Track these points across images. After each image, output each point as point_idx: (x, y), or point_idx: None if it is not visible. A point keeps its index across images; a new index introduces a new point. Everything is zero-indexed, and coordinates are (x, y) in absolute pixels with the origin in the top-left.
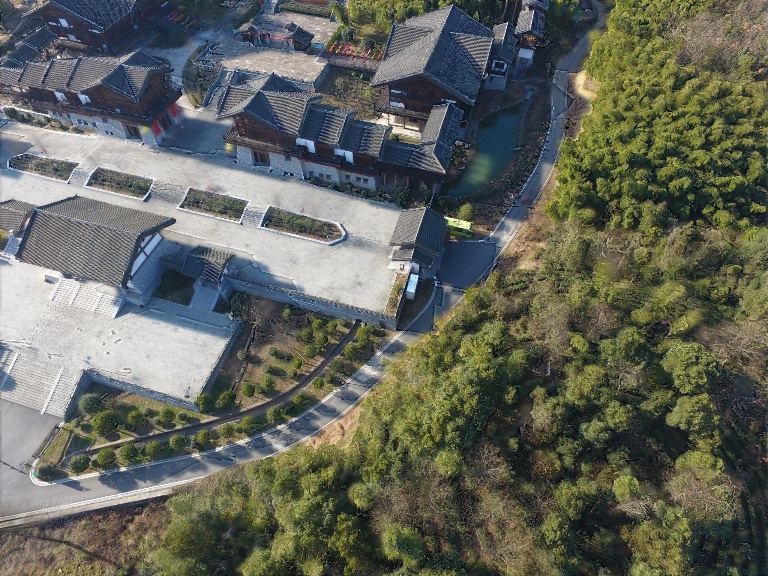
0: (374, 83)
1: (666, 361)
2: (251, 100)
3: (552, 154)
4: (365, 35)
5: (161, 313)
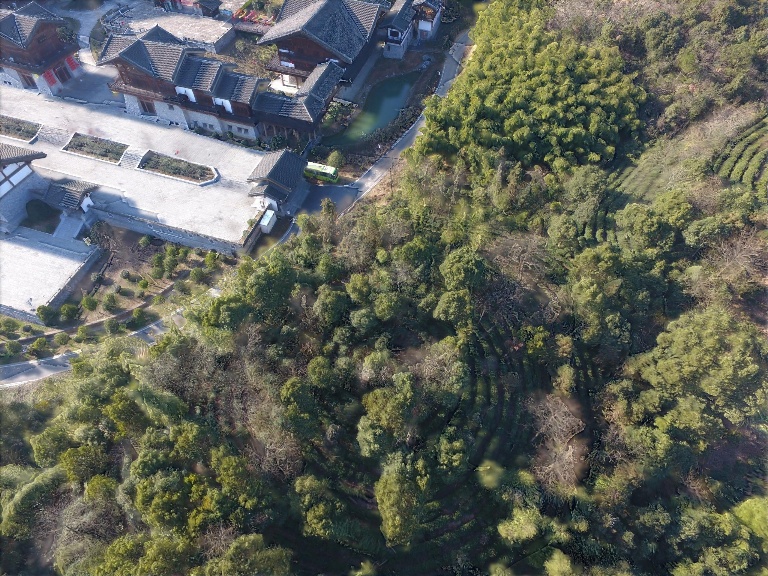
0: (260, 41)
1: (442, 264)
2: (128, 47)
3: None
4: (276, 6)
5: (25, 240)
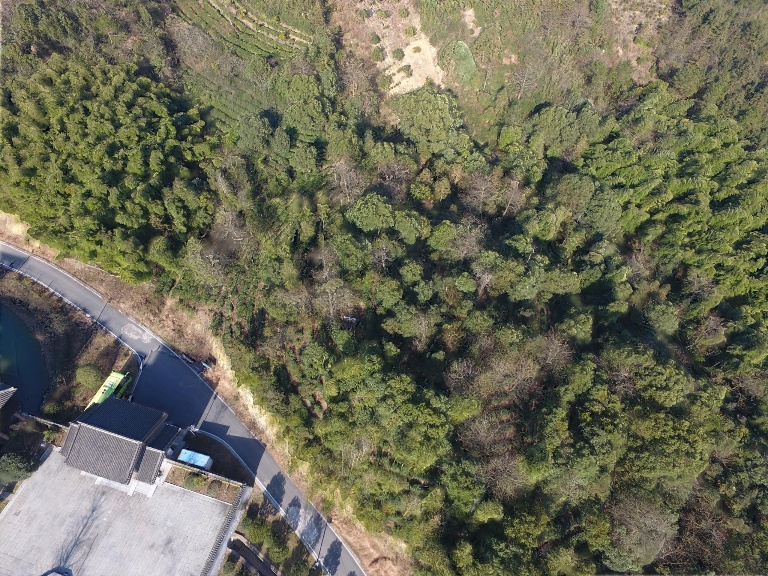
0: None
1: (366, 226)
2: None
3: (23, 260)
4: None
5: None
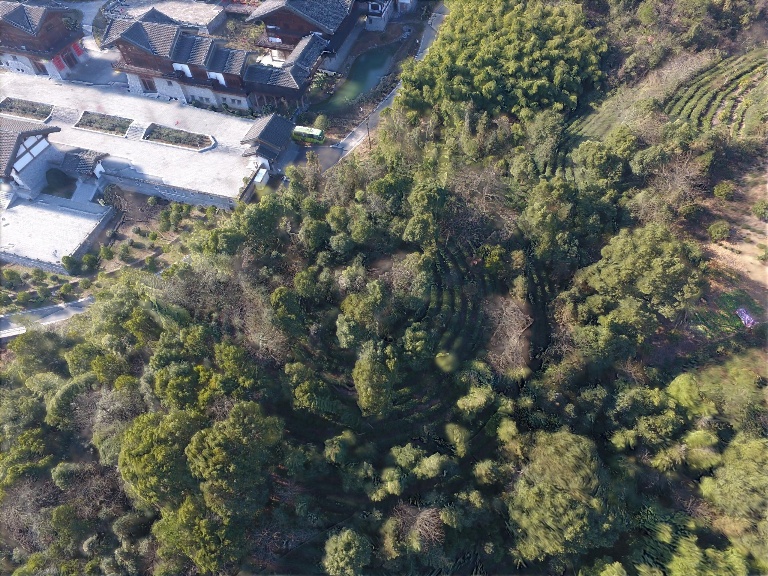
0: (249, 18)
1: None
2: (128, 28)
3: None
4: None
5: (46, 205)
